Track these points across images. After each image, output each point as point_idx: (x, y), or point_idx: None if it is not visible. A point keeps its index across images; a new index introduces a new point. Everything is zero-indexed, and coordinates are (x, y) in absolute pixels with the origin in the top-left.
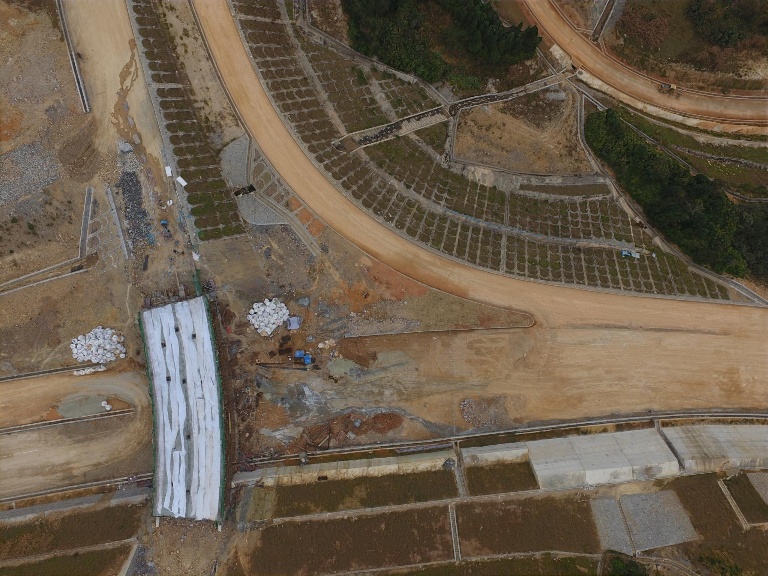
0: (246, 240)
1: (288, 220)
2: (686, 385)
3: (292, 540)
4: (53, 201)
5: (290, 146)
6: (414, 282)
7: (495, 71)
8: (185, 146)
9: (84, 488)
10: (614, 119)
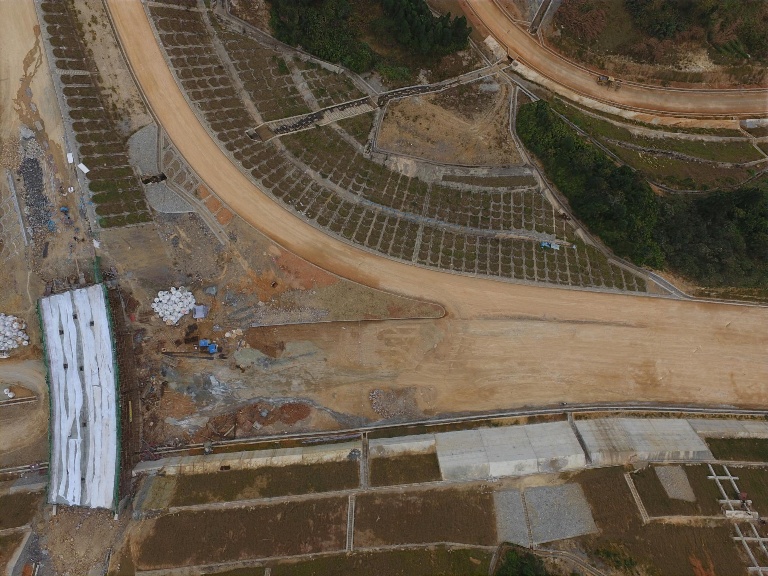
0: (153, 228)
1: (197, 208)
2: (601, 378)
3: (185, 529)
4: None
5: (199, 134)
6: (323, 272)
7: (427, 62)
8: (89, 133)
9: None
10: (543, 110)
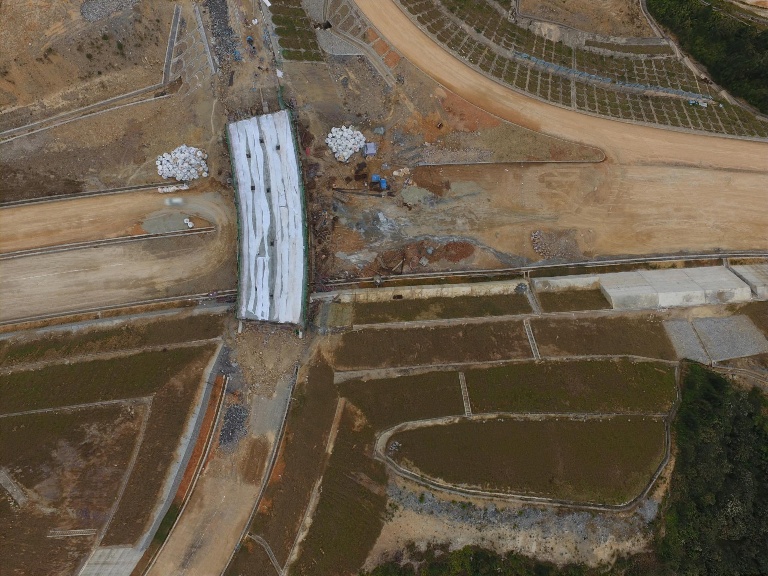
0: (324, 68)
1: (364, 52)
2: (755, 225)
3: (373, 342)
4: (142, 19)
5: None
6: (487, 114)
7: None
8: None
9: (166, 302)
10: None
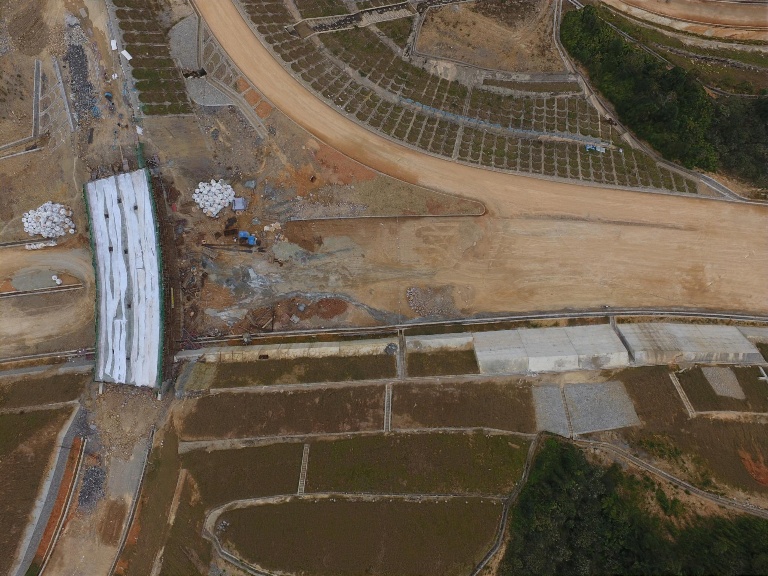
0: (193, 120)
1: (237, 102)
2: (646, 281)
3: (226, 408)
4: (3, 74)
5: (239, 26)
6: (362, 166)
7: None
8: (132, 21)
9: (36, 359)
10: (590, 15)
